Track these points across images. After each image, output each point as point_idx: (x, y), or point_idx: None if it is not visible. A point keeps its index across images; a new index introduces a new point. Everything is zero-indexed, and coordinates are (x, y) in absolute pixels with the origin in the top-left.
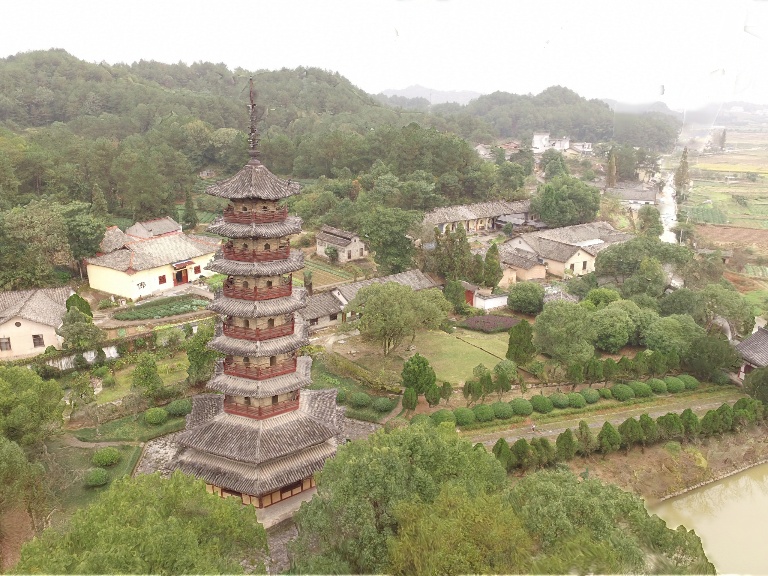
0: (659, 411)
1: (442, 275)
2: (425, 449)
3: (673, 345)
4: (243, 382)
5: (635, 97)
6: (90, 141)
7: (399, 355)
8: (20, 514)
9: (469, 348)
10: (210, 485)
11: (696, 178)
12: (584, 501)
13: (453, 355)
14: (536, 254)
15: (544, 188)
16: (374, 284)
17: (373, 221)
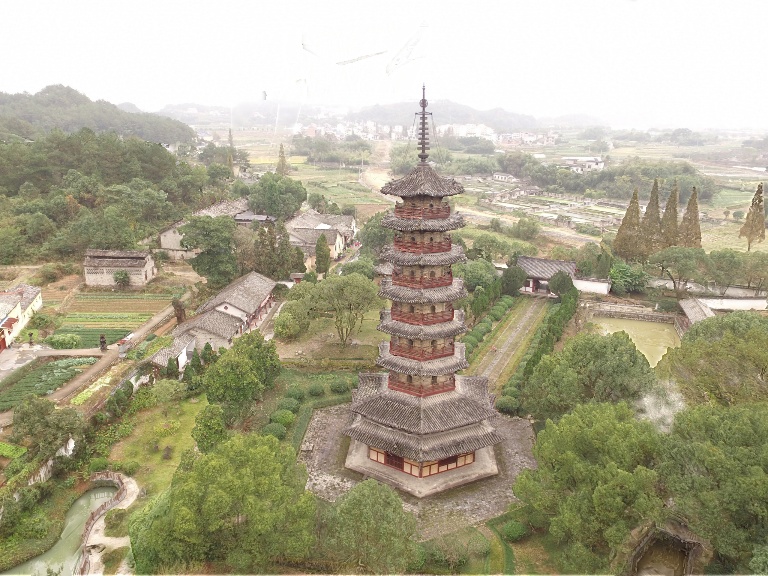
0: (521, 319)
1: (268, 273)
2: (623, 342)
3: (489, 279)
4: (439, 362)
5: (245, 101)
6: None
7: (333, 343)
8: None
9: (366, 322)
10: (428, 468)
11: (289, 170)
12: (756, 316)
13: (367, 330)
14: (304, 242)
15: (257, 185)
16: (334, 278)
17: (197, 231)
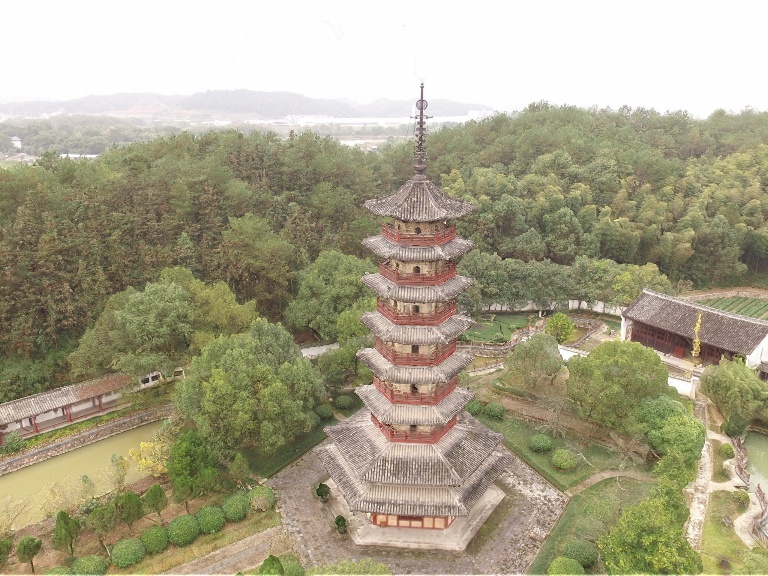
0: None
1: None
2: None
3: None
4: None
5: None
6: None
7: None
8: None
9: None
10: None
11: None
12: None
13: None
14: None
15: None
16: None
17: None
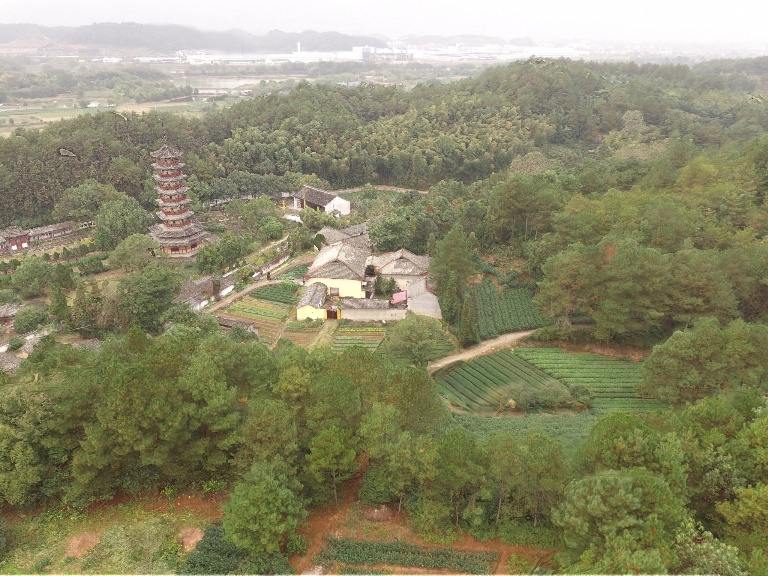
0: None
1: None
2: None
3: None
4: None
5: None
6: (697, 254)
7: None
8: (242, 230)
9: None
10: None
11: None
12: None
13: None
14: None
15: None
16: None
17: None
